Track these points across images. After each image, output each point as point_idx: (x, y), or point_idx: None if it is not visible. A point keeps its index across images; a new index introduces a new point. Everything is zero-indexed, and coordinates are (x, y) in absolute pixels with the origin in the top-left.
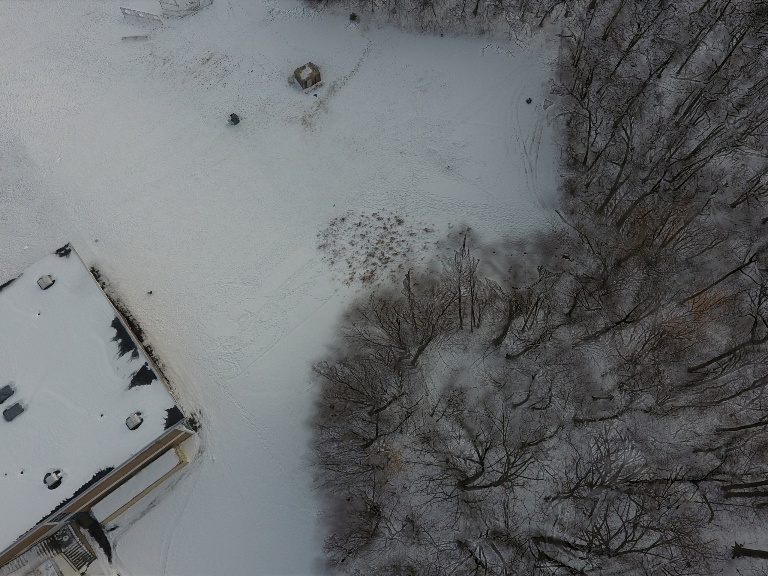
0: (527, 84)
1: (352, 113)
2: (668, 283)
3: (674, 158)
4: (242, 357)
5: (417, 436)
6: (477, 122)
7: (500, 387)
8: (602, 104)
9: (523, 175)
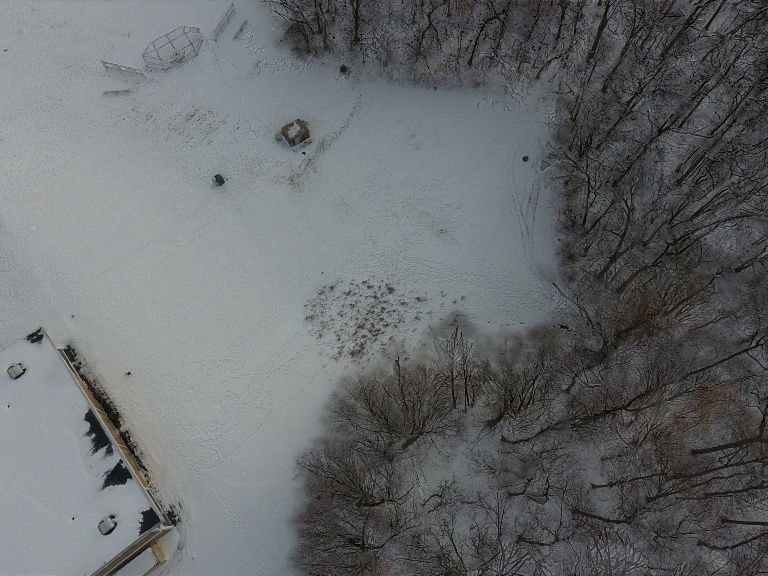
0: (523, 140)
1: (342, 172)
2: (670, 355)
3: (676, 220)
4: (224, 443)
5: (407, 529)
6: (472, 182)
7: (495, 474)
8: (601, 161)
9: (519, 239)
